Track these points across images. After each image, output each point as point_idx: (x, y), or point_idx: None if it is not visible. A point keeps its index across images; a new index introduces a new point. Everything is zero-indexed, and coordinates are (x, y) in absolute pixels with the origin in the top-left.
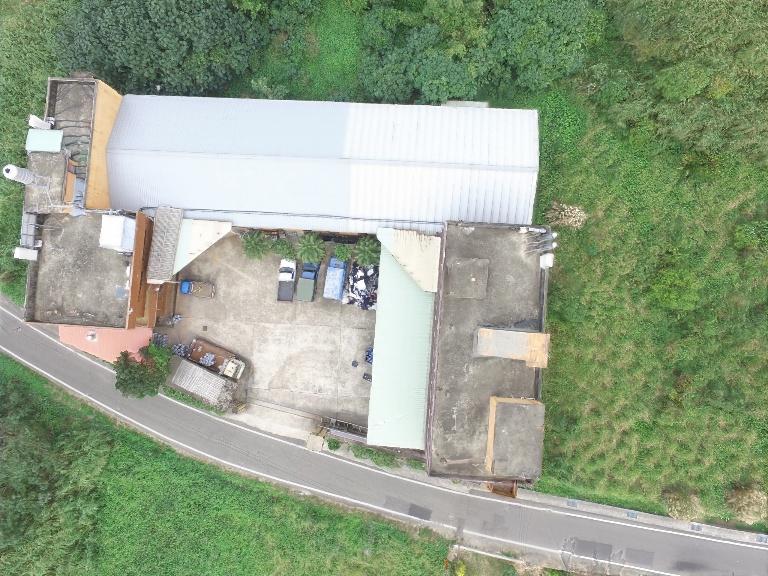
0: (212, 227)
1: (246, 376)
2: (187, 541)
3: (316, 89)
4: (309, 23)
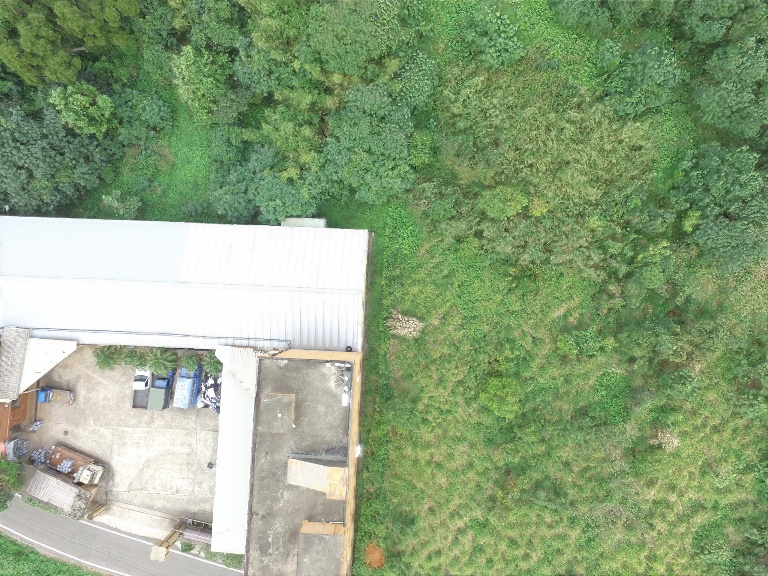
0: (58, 346)
1: (106, 479)
2: None
3: (171, 199)
4: (163, 135)
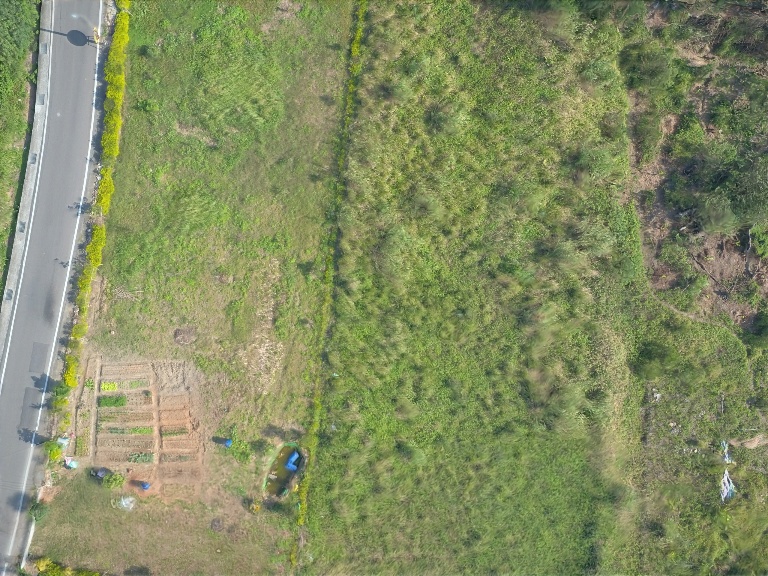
0: None
1: None
2: None
3: None
4: None
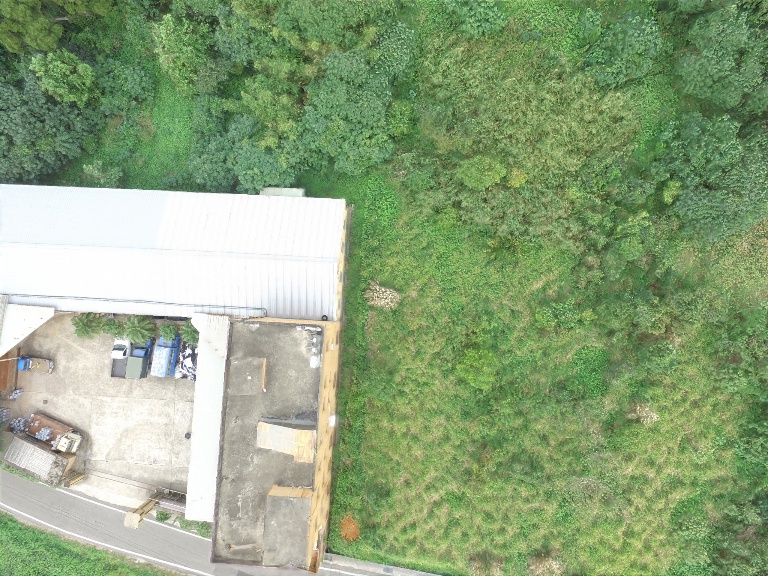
0: (36, 312)
1: (85, 448)
2: None
3: (153, 170)
4: (145, 107)
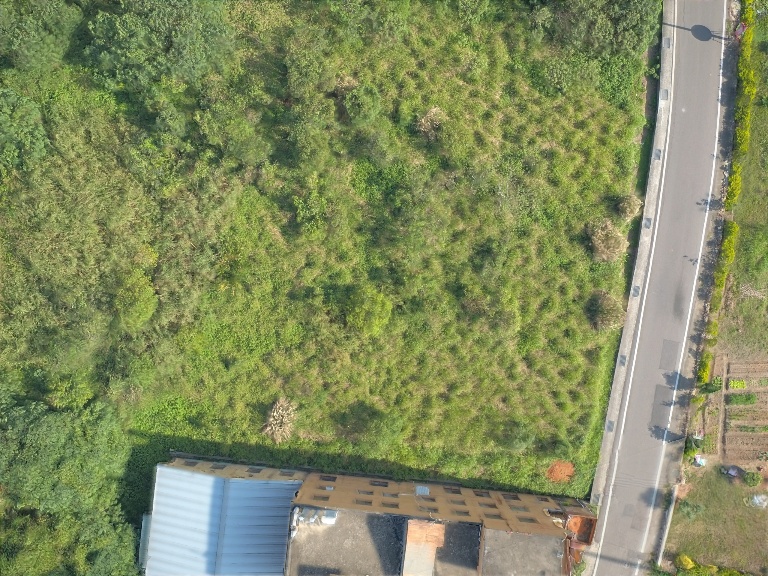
0: None
1: None
2: None
3: None
4: None
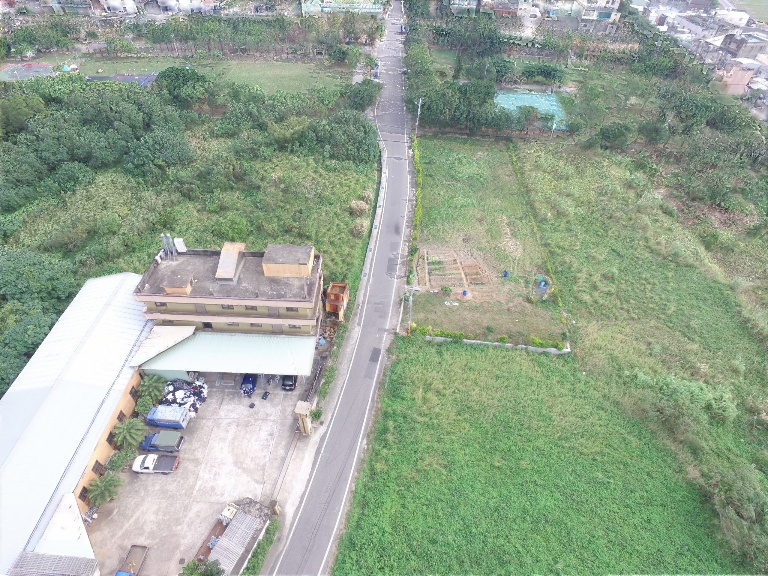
0: (60, 515)
1: None
2: (420, 568)
3: None
4: None
